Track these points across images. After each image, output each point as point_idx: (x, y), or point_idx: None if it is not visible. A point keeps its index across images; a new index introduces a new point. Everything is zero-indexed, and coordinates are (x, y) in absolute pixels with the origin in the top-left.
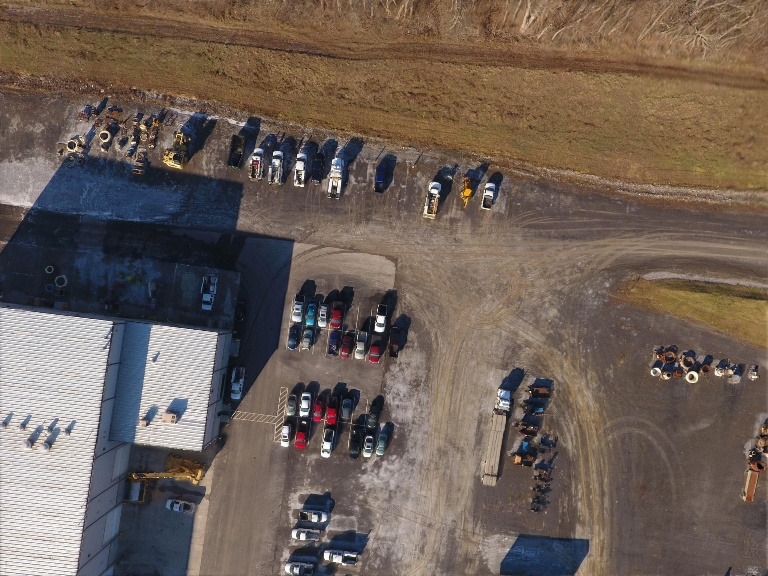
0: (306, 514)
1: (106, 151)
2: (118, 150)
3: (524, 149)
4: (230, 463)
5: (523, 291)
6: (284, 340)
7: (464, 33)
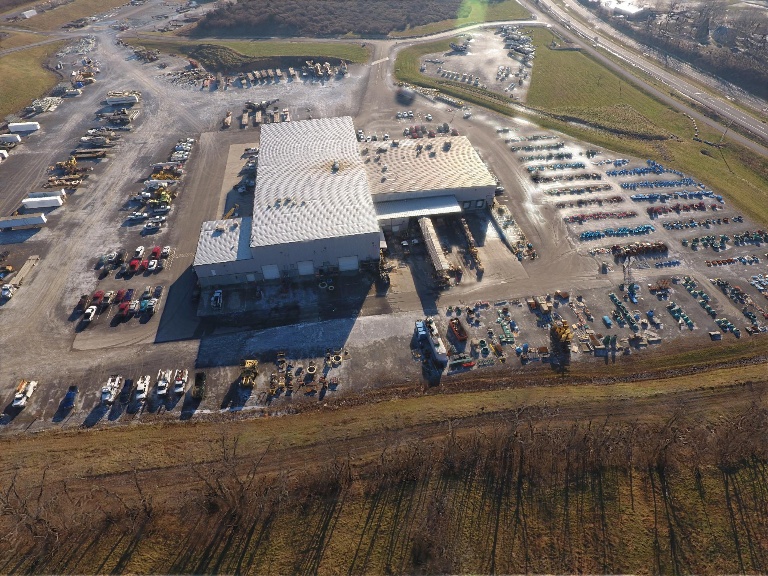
0: (156, 226)
1: None
2: None
3: None
4: None
5: None
6: (166, 290)
7: None
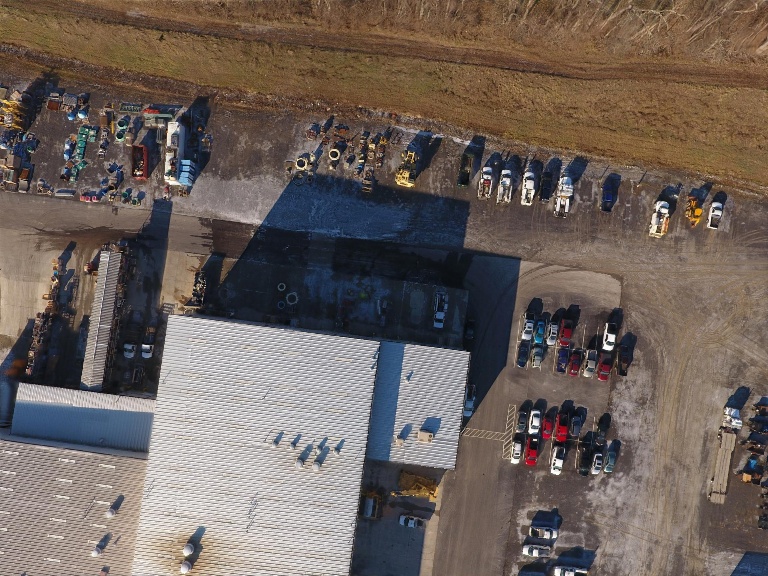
0: (536, 530)
1: (334, 169)
2: (346, 168)
3: (750, 168)
4: (459, 479)
5: (748, 310)
6: (512, 358)
7: (699, 53)
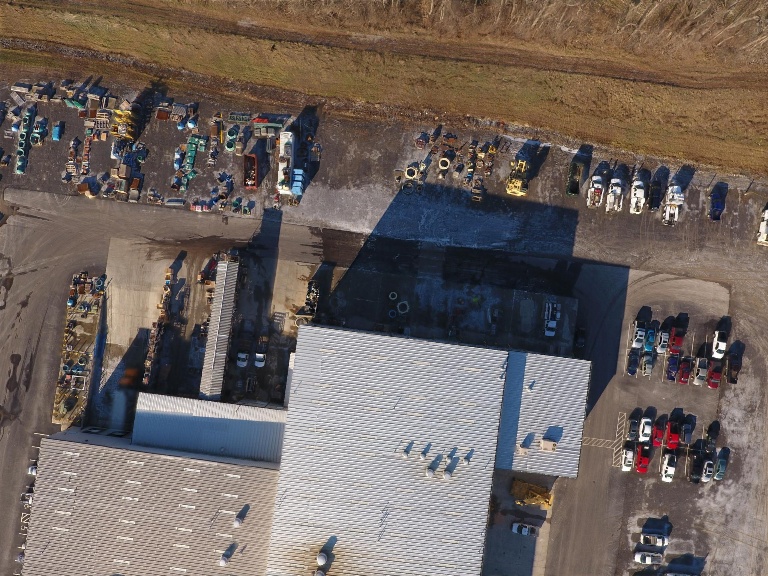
0: (648, 538)
1: (443, 178)
2: (455, 177)
3: None
4: (570, 487)
5: None
6: (622, 366)
7: None
